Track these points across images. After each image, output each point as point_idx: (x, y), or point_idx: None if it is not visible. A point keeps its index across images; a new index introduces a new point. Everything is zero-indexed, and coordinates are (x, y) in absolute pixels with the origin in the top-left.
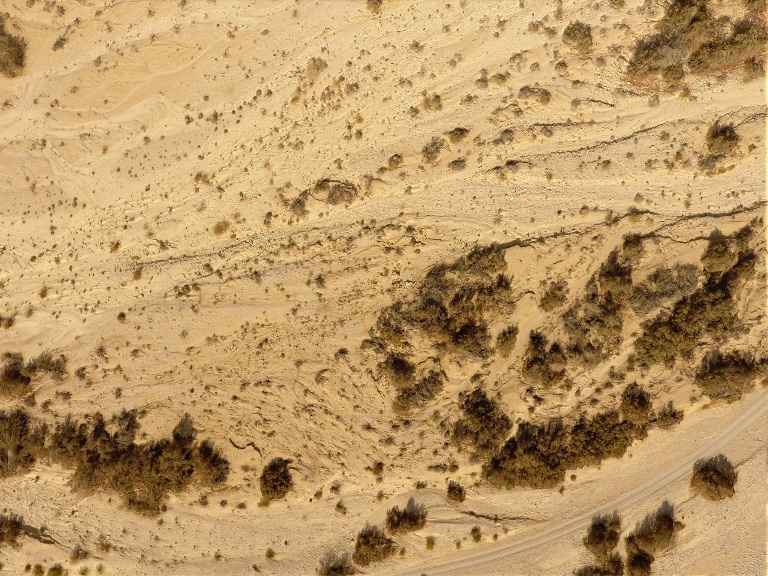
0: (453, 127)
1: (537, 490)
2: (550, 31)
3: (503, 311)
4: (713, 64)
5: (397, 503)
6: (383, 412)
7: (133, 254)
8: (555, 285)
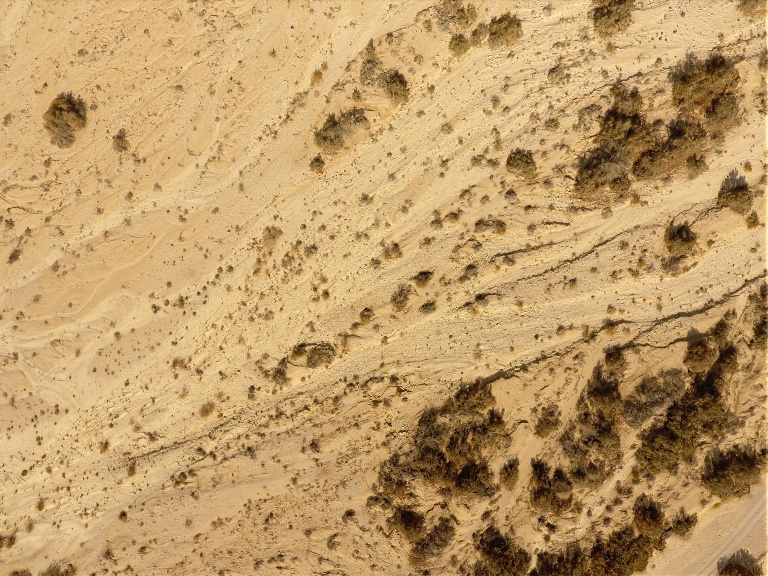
0: (417, 272)
1: None
2: (493, 163)
3: (500, 445)
4: (657, 170)
5: None
6: (401, 566)
7: (124, 450)
8: (546, 411)
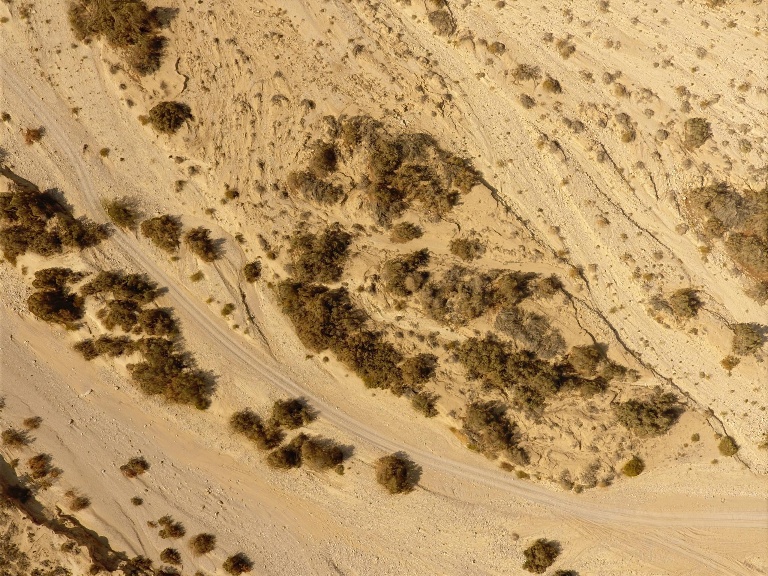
0: (557, 78)
1: (297, 336)
2: (687, 106)
3: (429, 214)
4: (744, 254)
5: (213, 230)
6: (282, 169)
7: None
8: (477, 242)
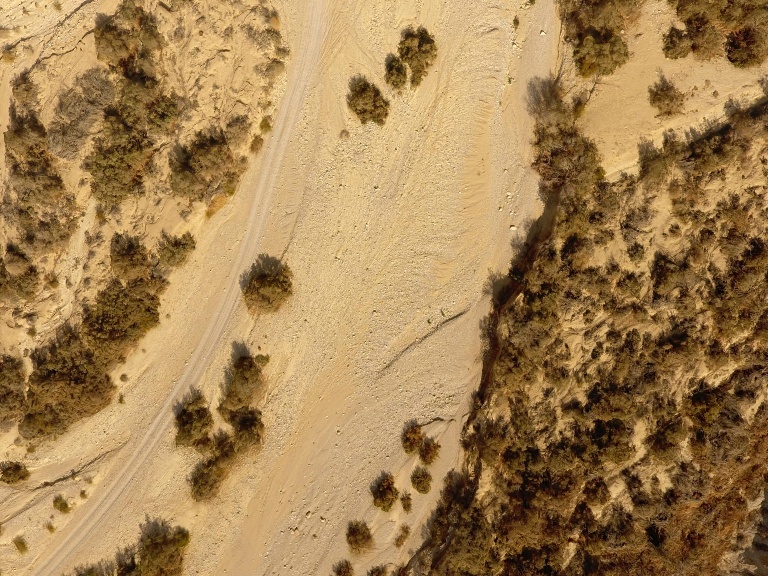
0: None
1: (95, 416)
2: None
3: None
4: None
5: None
6: None
7: None
8: None
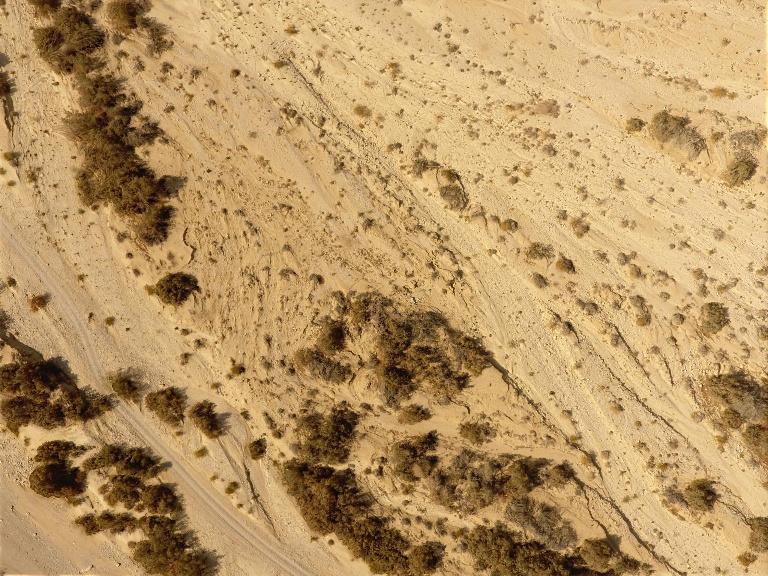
0: (570, 257)
1: (302, 517)
2: (704, 290)
3: (438, 395)
4: (762, 449)
5: (218, 404)
6: (289, 345)
7: (295, 50)
8: (487, 427)
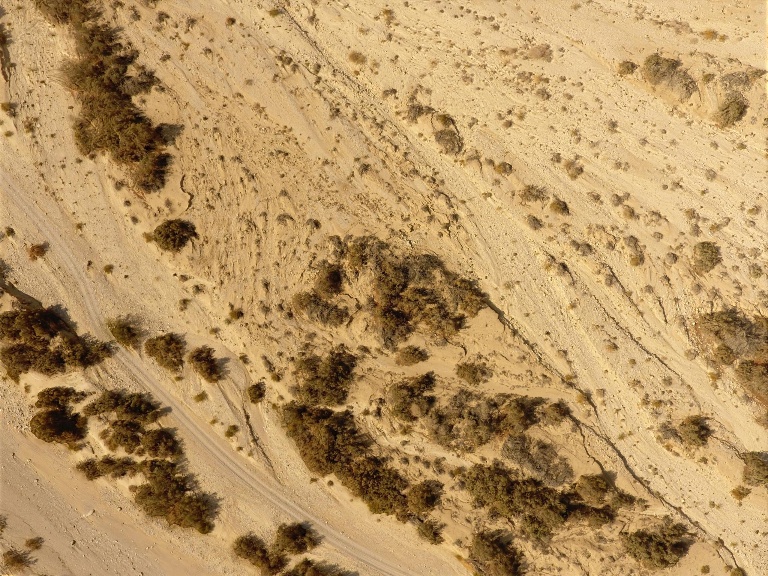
0: (564, 199)
1: (301, 459)
2: (697, 230)
3: (435, 337)
4: (755, 383)
5: (217, 349)
6: (287, 289)
7: None
8: (484, 367)
